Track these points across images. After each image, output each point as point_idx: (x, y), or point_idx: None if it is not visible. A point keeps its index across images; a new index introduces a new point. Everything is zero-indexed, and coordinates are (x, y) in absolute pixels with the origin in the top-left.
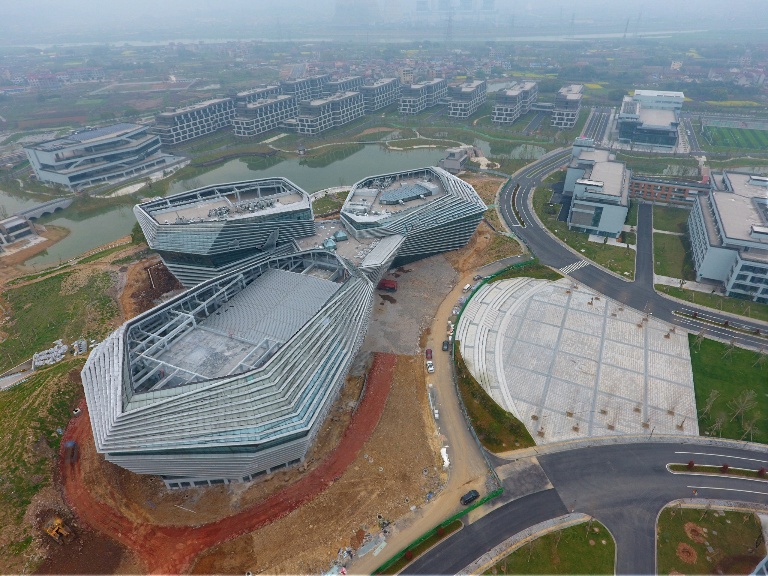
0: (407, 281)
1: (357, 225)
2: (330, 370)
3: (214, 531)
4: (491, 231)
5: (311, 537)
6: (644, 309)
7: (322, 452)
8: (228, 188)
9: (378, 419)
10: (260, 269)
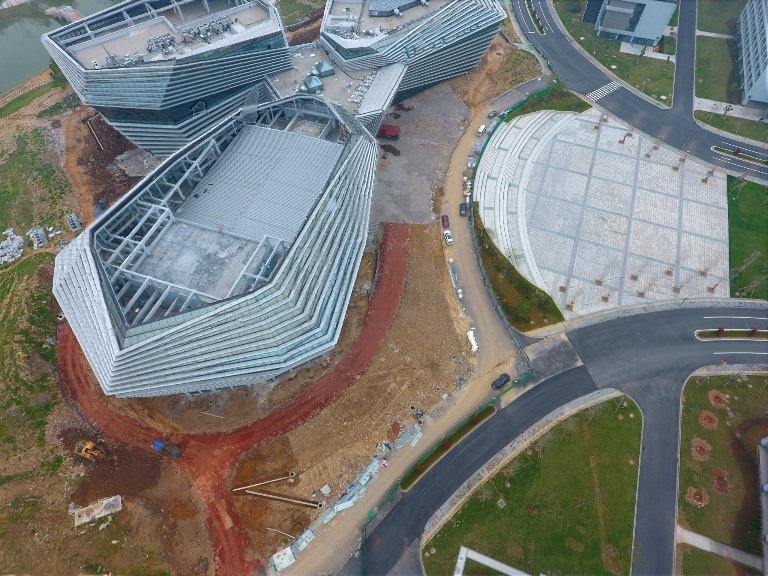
0: (410, 123)
1: (345, 53)
2: (346, 267)
3: (248, 435)
4: (504, 43)
5: (347, 434)
6: (682, 147)
7: (343, 344)
8: None
9: (398, 303)
10: (233, 127)
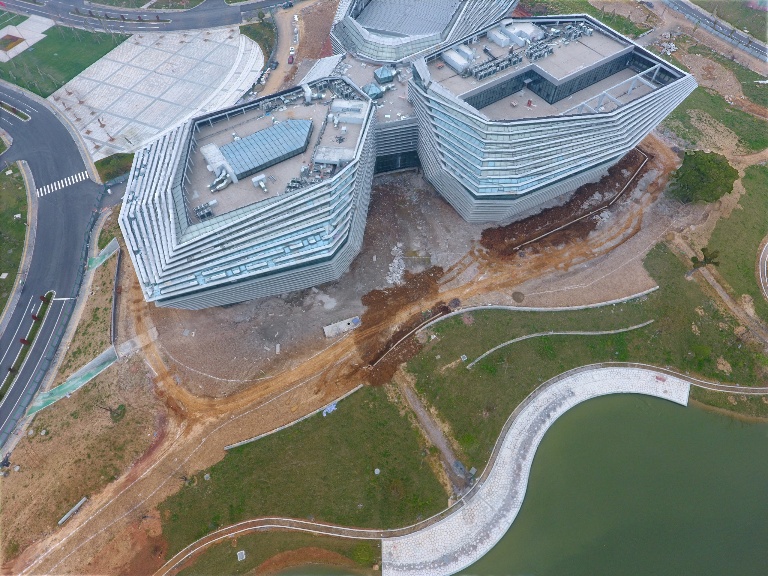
0: None
1: None
2: None
3: None
4: None
5: None
6: None
7: None
8: None
9: None
10: None
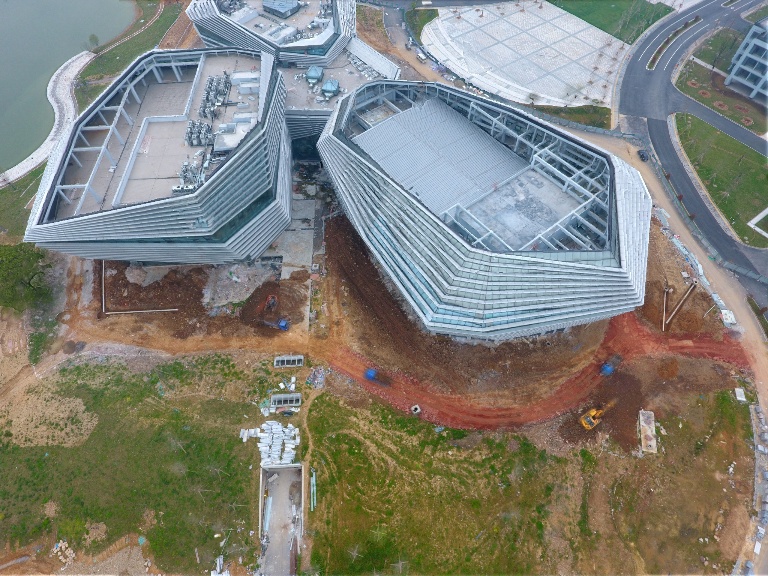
0: None
1: (322, 49)
2: None
3: None
4: None
5: None
6: None
7: None
8: (93, 115)
9: None
10: None
